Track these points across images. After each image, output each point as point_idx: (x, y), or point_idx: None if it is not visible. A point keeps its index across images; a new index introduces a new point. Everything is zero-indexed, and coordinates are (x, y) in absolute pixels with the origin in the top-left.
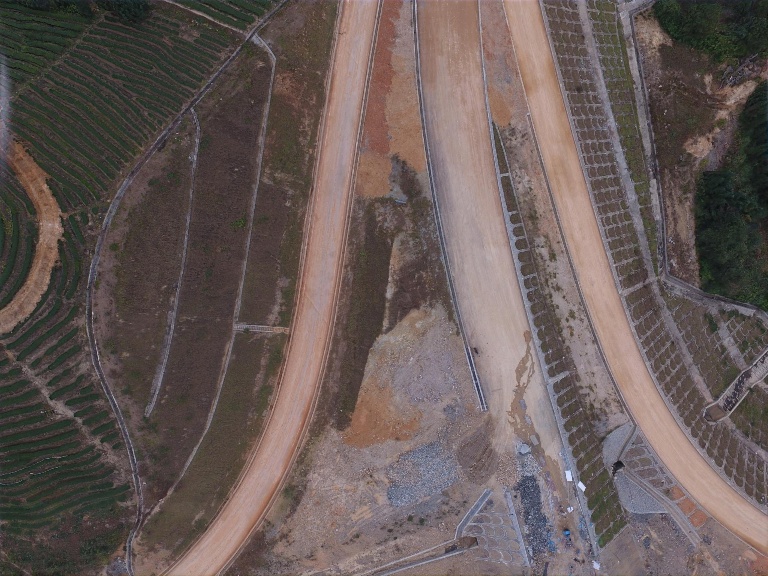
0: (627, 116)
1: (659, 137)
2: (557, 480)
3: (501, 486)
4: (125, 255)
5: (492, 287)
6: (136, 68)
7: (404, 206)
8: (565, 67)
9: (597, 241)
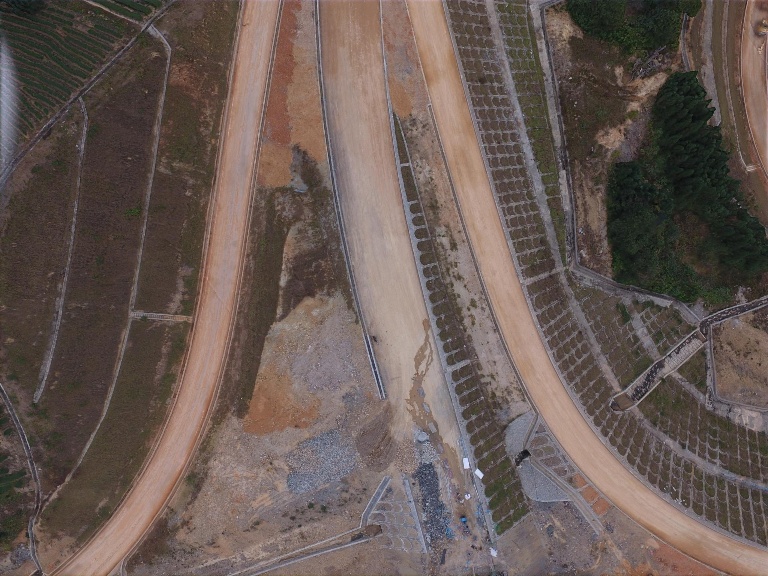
0: (536, 107)
1: (569, 128)
2: (455, 467)
3: (400, 473)
4: (6, 241)
5: (391, 276)
6: (26, 58)
7: (304, 195)
8: (467, 58)
9: (498, 231)
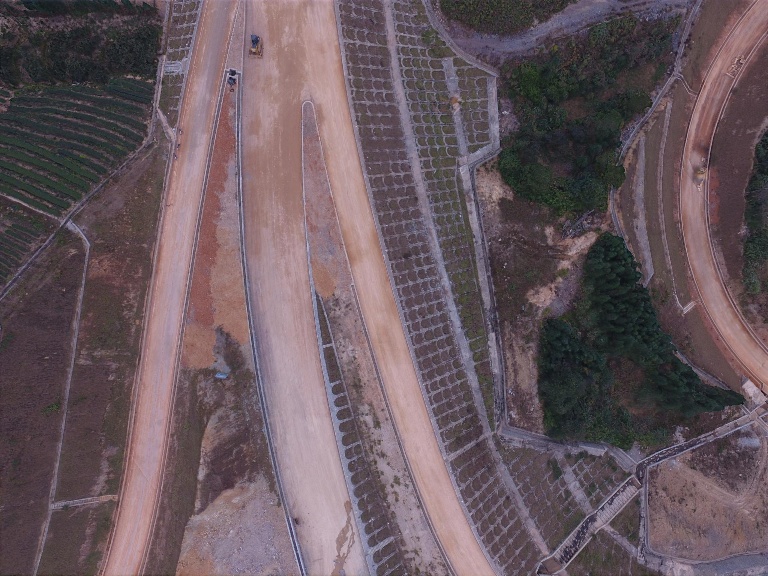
0: (464, 272)
1: (499, 290)
2: None
3: None
4: None
5: (314, 458)
6: None
7: (226, 379)
8: (391, 236)
9: (422, 408)
